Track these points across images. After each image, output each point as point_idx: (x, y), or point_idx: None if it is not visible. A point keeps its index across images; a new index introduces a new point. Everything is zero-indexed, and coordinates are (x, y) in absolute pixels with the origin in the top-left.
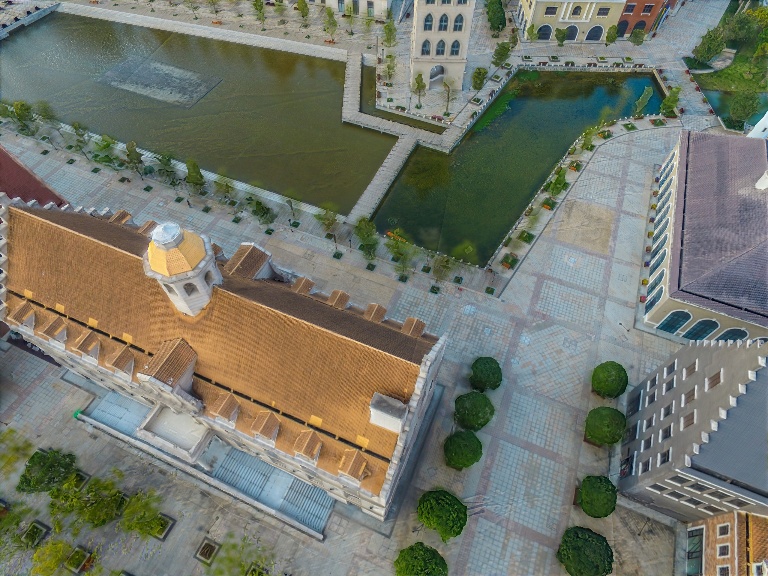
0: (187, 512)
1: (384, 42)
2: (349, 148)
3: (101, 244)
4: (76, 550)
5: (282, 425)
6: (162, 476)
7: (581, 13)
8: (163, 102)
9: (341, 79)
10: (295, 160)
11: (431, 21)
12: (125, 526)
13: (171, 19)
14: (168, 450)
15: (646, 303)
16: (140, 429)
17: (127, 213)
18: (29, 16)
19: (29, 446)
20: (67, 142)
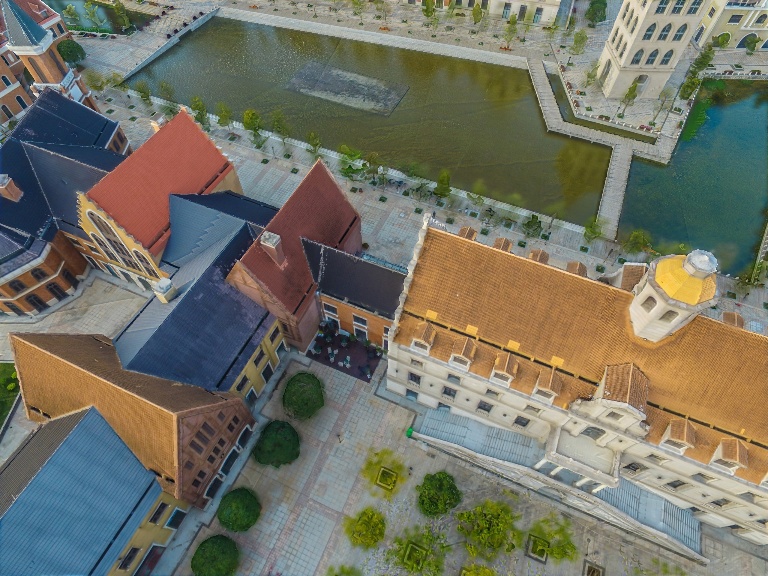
0: (556, 534)
1: (570, 50)
2: (564, 158)
3: (546, 267)
4: (464, 572)
5: (749, 453)
6: (516, 496)
7: (765, 21)
8: (360, 110)
9: (528, 87)
10: (515, 170)
11: (652, 30)
12: (500, 548)
13: (337, 25)
14: (587, 474)
15: None
16: (555, 453)
17: (473, 230)
18: (195, 21)
19: (371, 464)
20: (283, 151)
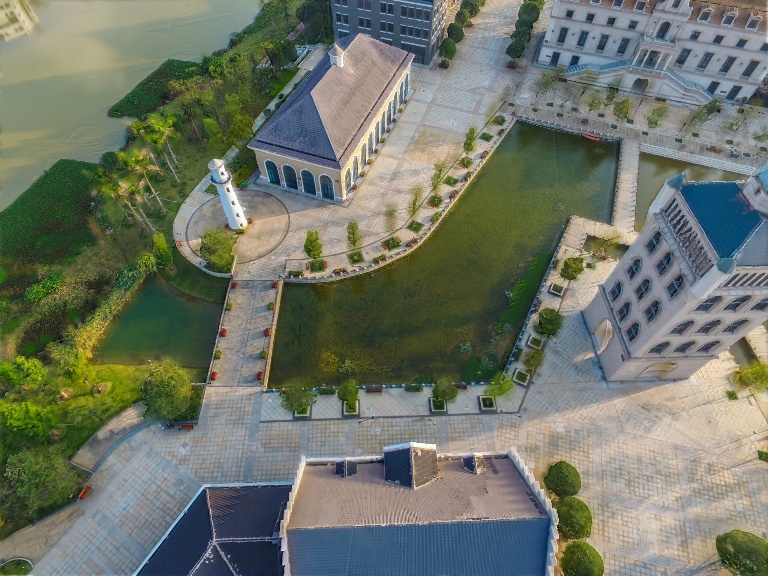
0: None
1: None
2: None
3: None
4: None
5: None
6: None
7: None
8: None
9: None
10: None
11: None
12: None
13: None
14: None
15: (404, 99)
16: None
17: None
18: None
19: None
20: None
